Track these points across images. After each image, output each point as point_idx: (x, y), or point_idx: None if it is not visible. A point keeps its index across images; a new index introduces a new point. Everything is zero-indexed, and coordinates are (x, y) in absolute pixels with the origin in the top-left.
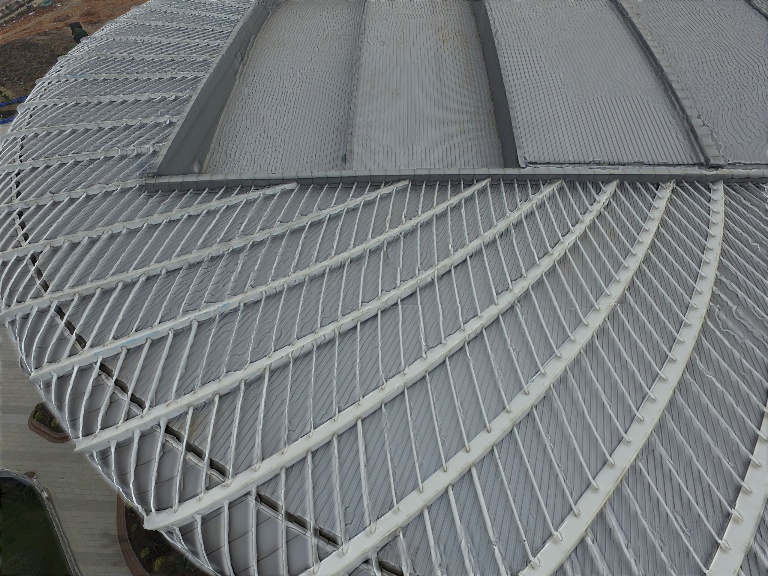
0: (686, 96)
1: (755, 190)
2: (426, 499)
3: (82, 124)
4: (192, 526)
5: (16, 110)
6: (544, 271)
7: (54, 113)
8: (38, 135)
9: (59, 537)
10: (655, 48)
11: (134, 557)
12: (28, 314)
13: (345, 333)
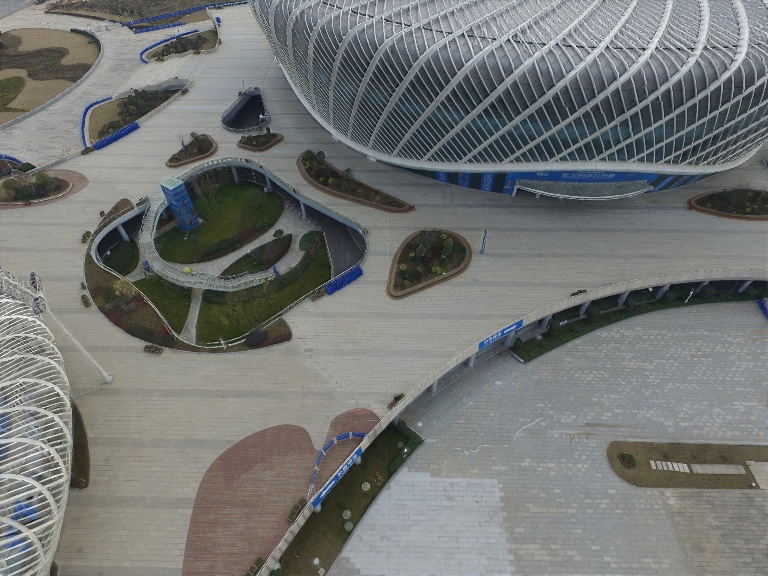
0: None
1: None
2: (480, 19)
3: None
4: (400, 39)
5: (144, 25)
6: None
7: None
8: None
9: (276, 175)
10: None
11: (316, 182)
12: (308, 7)
13: None
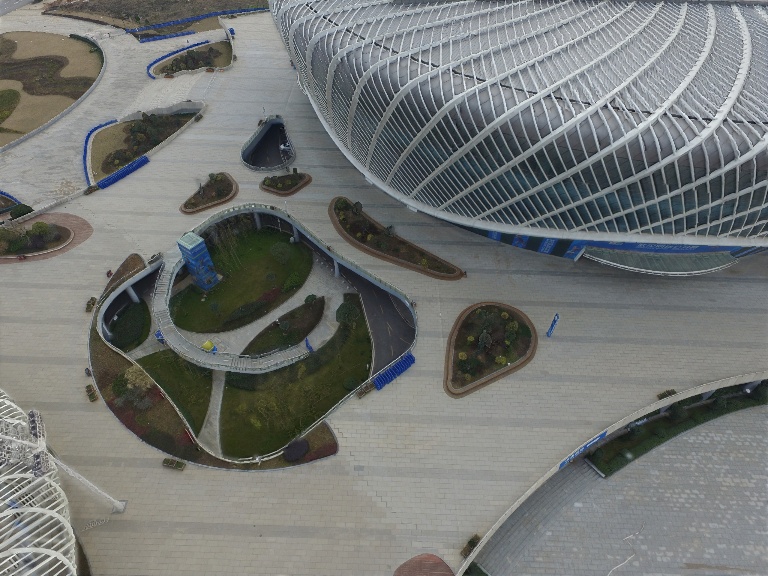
0: None
1: (702, 6)
2: (569, 77)
3: None
4: (472, 97)
5: (150, 34)
6: (605, 25)
7: None
8: None
9: (306, 228)
10: None
11: (352, 238)
12: (357, 48)
13: (521, 41)
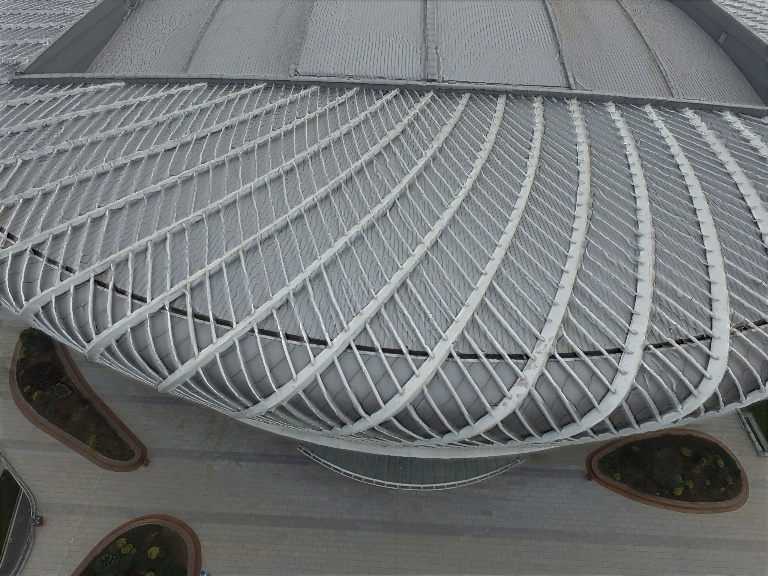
0: (433, 34)
1: (454, 97)
2: (131, 247)
3: None
4: None
5: None
6: (270, 136)
7: None
8: None
9: None
10: (431, 1)
11: (19, 393)
12: None
13: (118, 166)
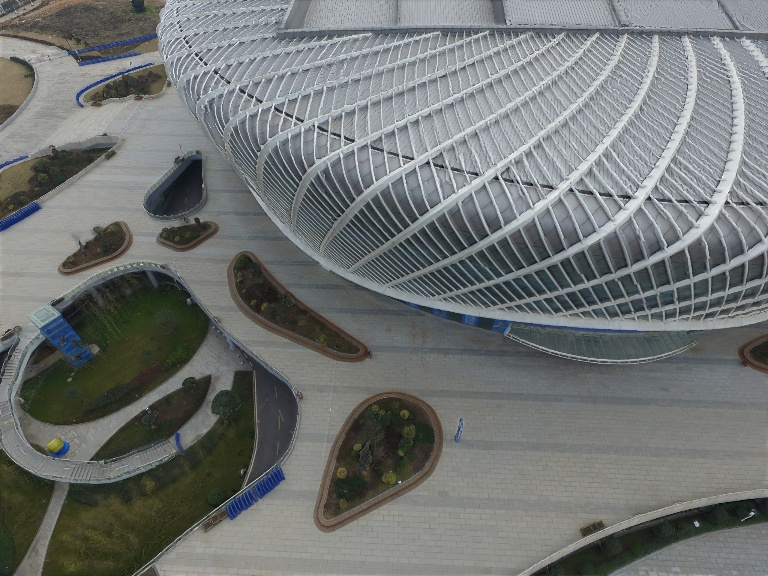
0: None
1: (646, 38)
2: (454, 139)
3: (222, 11)
4: (336, 162)
5: (92, 56)
6: (517, 66)
7: (197, 8)
8: (189, 20)
9: (194, 294)
10: None
11: (246, 306)
12: (220, 95)
13: (409, 88)
